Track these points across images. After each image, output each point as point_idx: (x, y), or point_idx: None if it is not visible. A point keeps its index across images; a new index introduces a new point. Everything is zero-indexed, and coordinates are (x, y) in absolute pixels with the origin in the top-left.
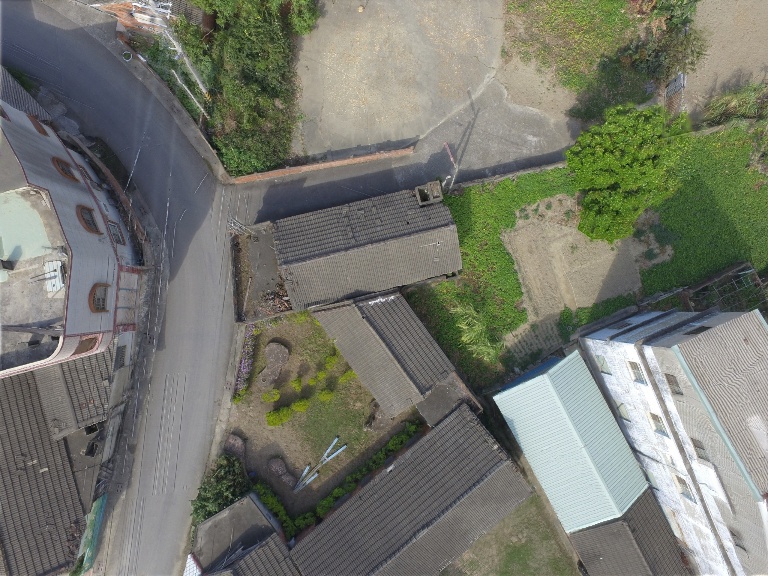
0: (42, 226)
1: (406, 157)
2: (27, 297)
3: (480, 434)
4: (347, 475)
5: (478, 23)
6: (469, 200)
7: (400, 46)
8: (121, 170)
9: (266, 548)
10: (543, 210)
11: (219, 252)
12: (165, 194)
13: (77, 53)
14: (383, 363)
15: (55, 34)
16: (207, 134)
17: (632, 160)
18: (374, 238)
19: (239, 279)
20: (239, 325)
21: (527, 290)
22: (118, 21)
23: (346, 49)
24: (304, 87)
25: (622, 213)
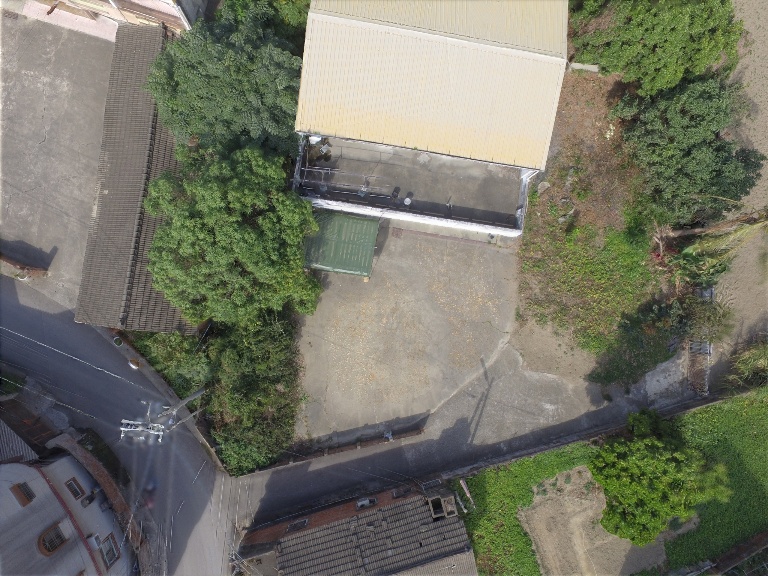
0: None
1: None
2: None
3: None
4: None
5: (491, 286)
6: (484, 479)
7: (408, 316)
8: (114, 462)
9: None
10: (562, 484)
11: (220, 545)
12: (161, 486)
13: (65, 338)
14: None
15: (41, 319)
16: (205, 419)
17: (662, 498)
18: (385, 567)
19: None
20: None
21: (546, 571)
22: None
23: (351, 322)
24: (307, 365)
25: (649, 529)
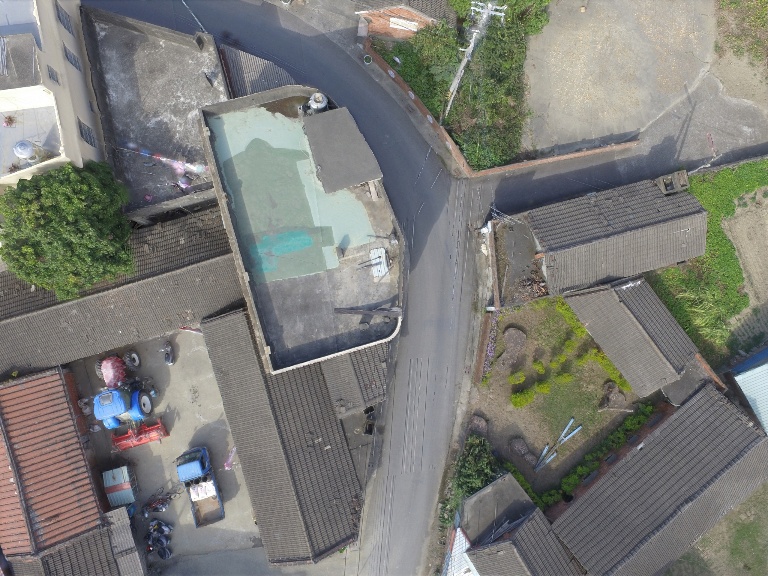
0: (366, 216)
1: (628, 149)
2: (356, 282)
3: (731, 412)
4: (585, 454)
5: (692, 20)
6: (691, 189)
7: (620, 44)
8: None
9: (533, 521)
10: (760, 198)
11: (456, 243)
12: (404, 189)
13: (320, 58)
14: (638, 345)
15: (300, 40)
16: None
17: None
18: (630, 225)
19: (497, 266)
20: (475, 312)
21: (748, 275)
22: (359, 27)
23: (570, 48)
24: (532, 85)
25: None
